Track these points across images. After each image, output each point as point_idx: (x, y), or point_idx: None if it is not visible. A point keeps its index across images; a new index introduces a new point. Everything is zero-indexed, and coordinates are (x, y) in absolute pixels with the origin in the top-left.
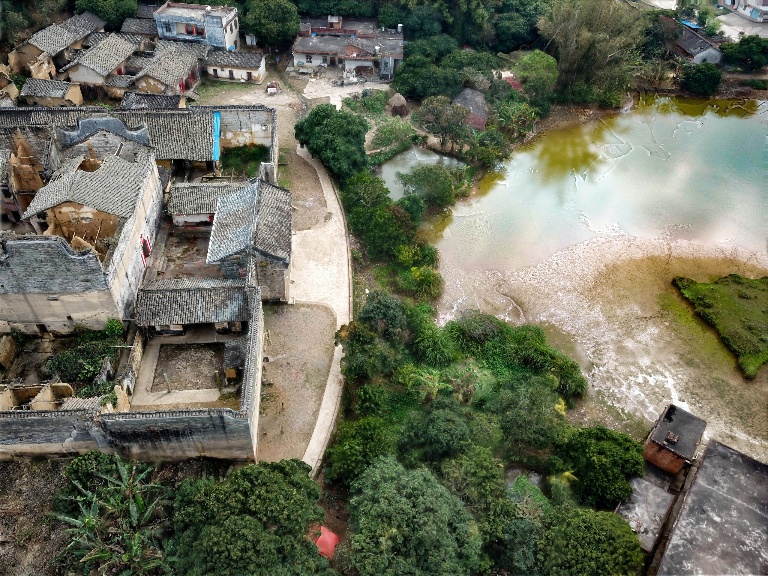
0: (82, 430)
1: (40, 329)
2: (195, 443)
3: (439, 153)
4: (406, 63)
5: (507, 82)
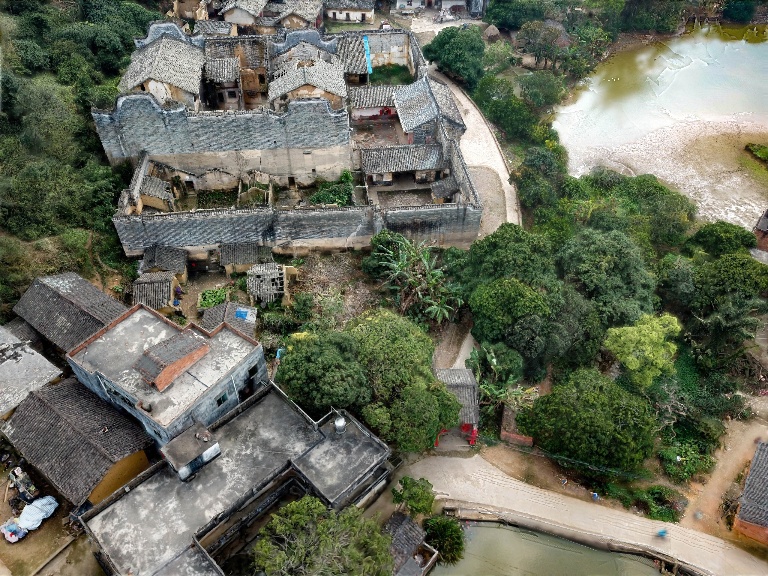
0: (365, 225)
1: (289, 182)
2: (440, 235)
3: (534, 70)
4: (496, 0)
5: (582, 12)
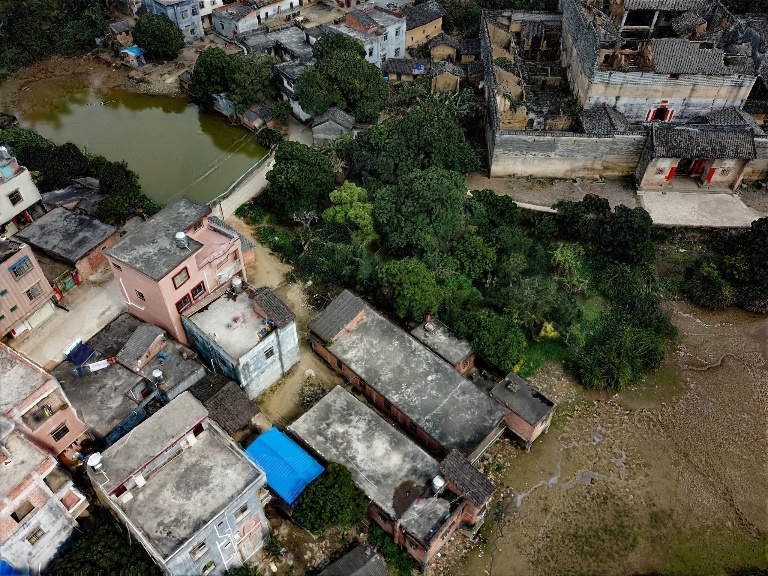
0: None
1: None
2: None
3: None
4: None
5: None
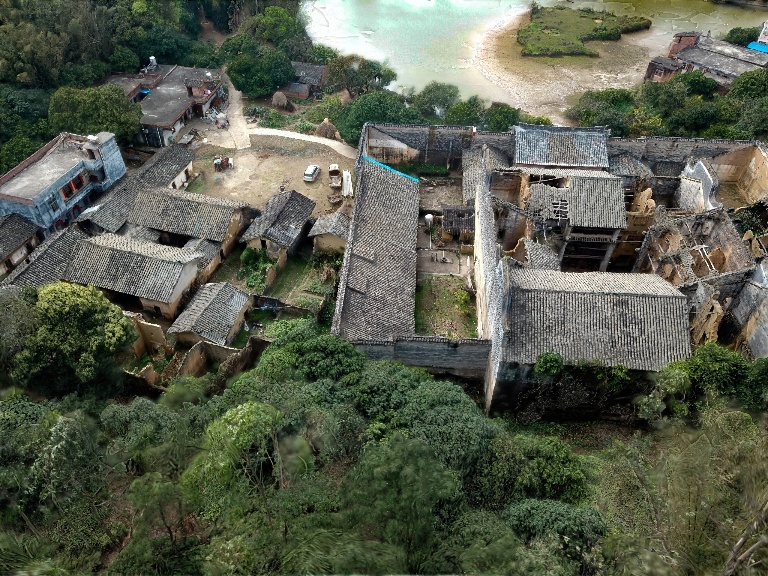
0: None
1: None
2: None
3: None
4: (240, 70)
5: None
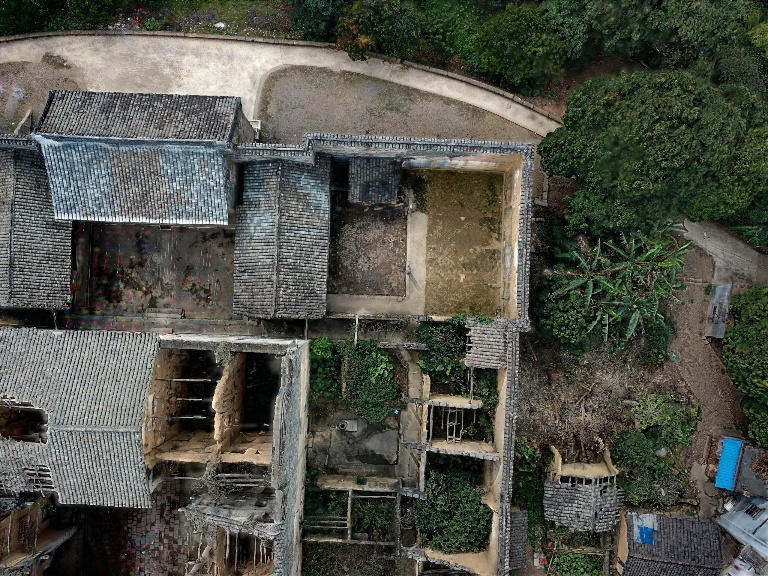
0: None
1: None
2: None
3: None
4: None
5: None
